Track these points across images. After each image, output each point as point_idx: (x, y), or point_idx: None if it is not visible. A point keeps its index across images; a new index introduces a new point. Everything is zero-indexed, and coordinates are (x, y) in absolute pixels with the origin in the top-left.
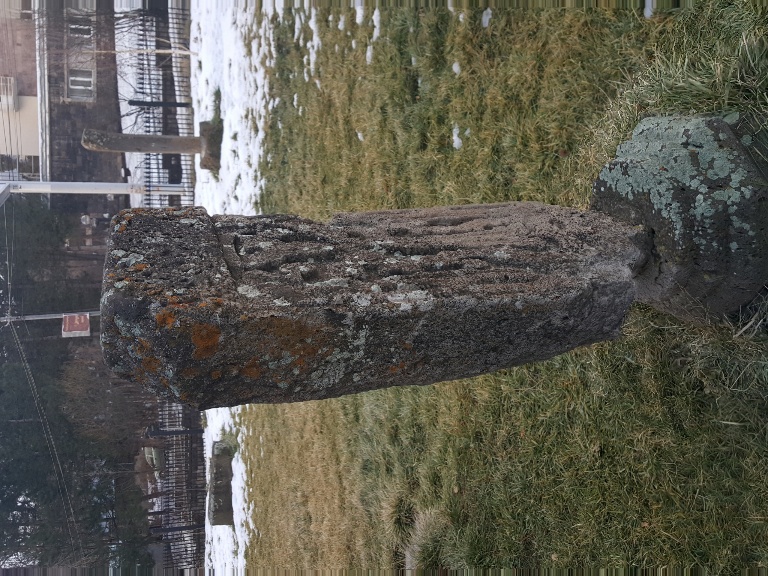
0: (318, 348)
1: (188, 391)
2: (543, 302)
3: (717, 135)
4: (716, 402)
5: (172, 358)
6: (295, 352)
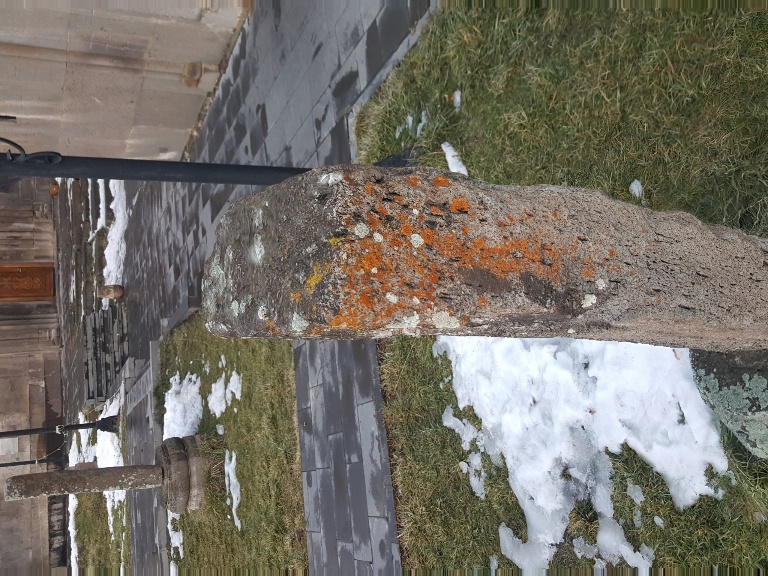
0: None
1: None
2: None
3: None
4: (762, 181)
5: None
6: None
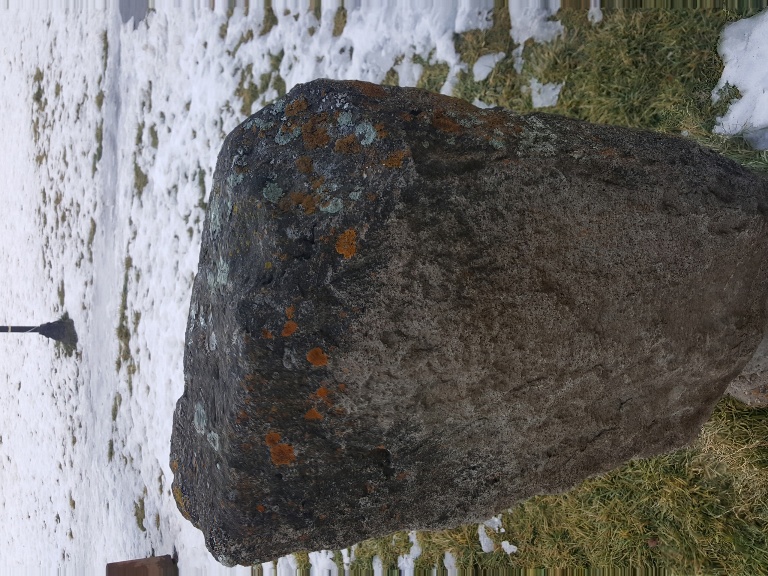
0: None
1: None
2: (673, 134)
3: None
4: None
5: (339, 92)
6: None
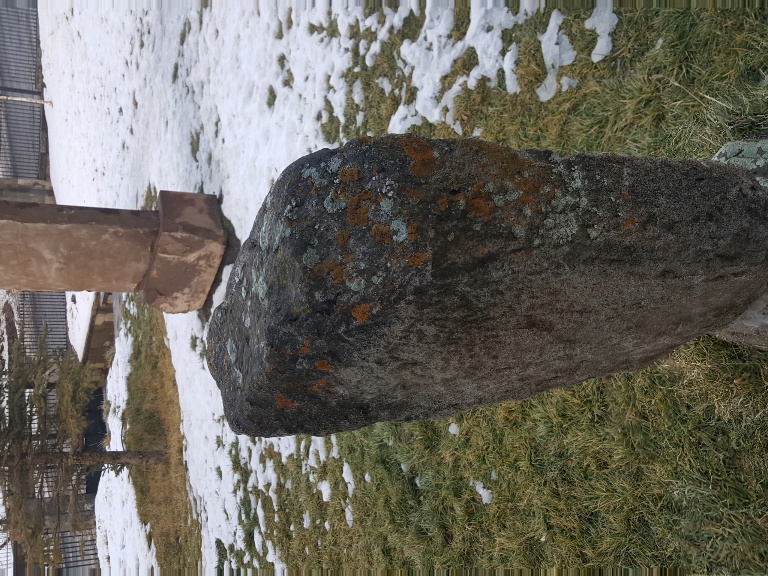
0: (538, 186)
1: (417, 222)
2: (723, 165)
3: (747, 140)
4: None
5: (389, 173)
6: (517, 186)
